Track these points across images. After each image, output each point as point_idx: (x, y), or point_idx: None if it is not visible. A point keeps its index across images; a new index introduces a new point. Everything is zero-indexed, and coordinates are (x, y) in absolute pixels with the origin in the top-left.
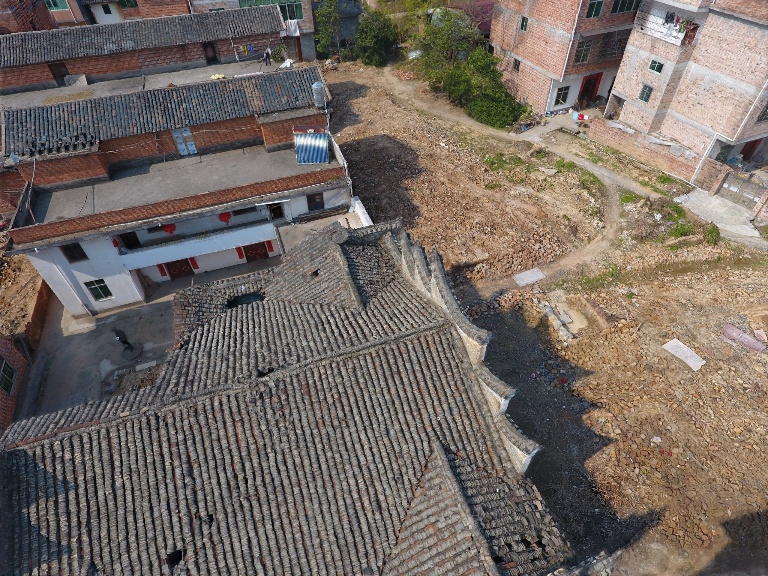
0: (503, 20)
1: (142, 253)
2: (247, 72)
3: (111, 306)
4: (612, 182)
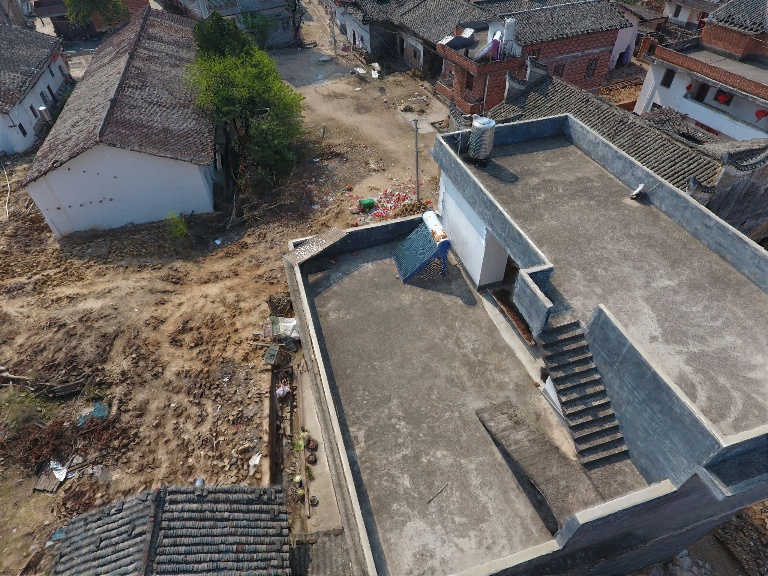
0: None
1: (694, 104)
2: None
3: None
4: None
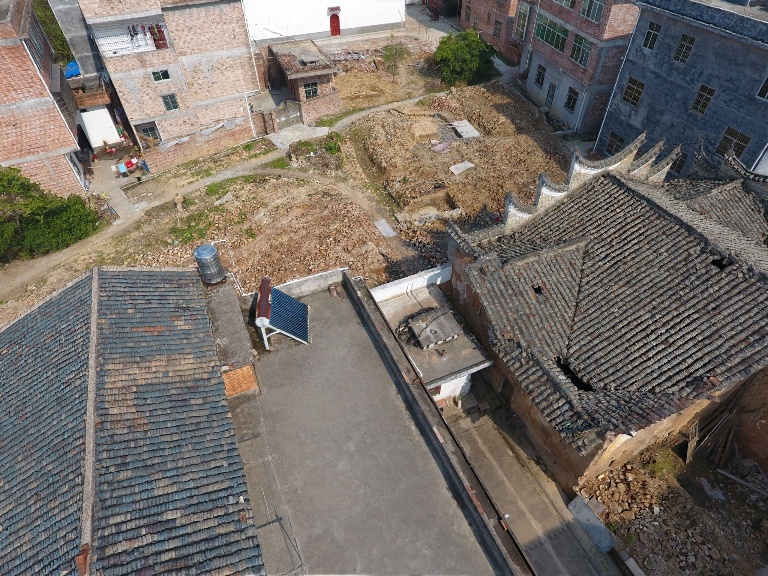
0: None
1: None
2: None
3: None
4: (247, 171)
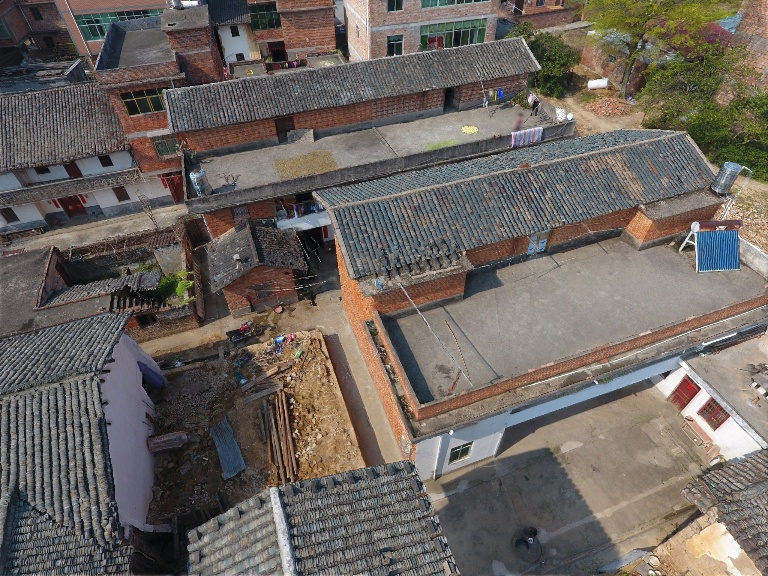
0: (749, 50)
1: (533, 408)
2: (502, 123)
3: (458, 466)
4: None
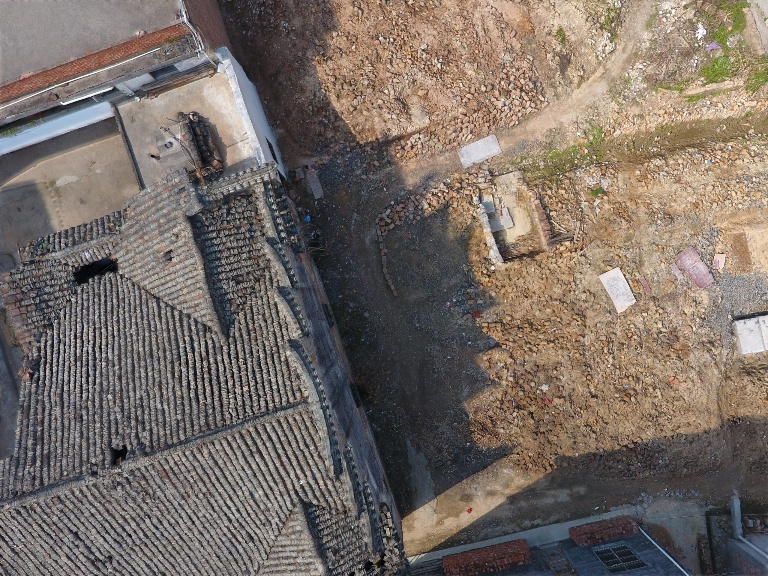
0: None
1: None
2: None
3: None
4: None
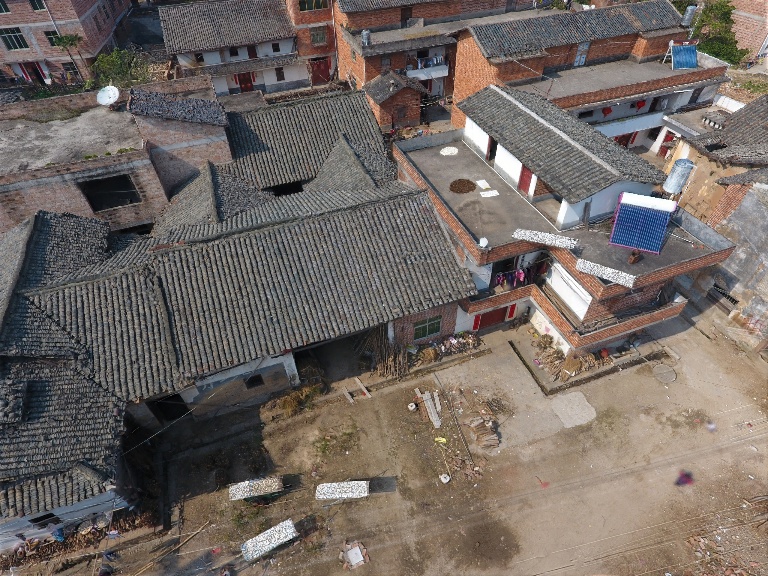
0: None
1: None
2: None
3: None
4: None
